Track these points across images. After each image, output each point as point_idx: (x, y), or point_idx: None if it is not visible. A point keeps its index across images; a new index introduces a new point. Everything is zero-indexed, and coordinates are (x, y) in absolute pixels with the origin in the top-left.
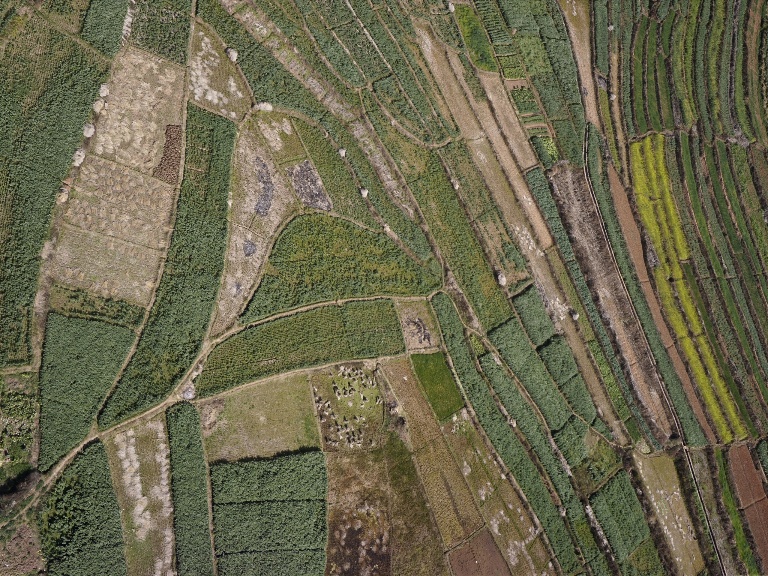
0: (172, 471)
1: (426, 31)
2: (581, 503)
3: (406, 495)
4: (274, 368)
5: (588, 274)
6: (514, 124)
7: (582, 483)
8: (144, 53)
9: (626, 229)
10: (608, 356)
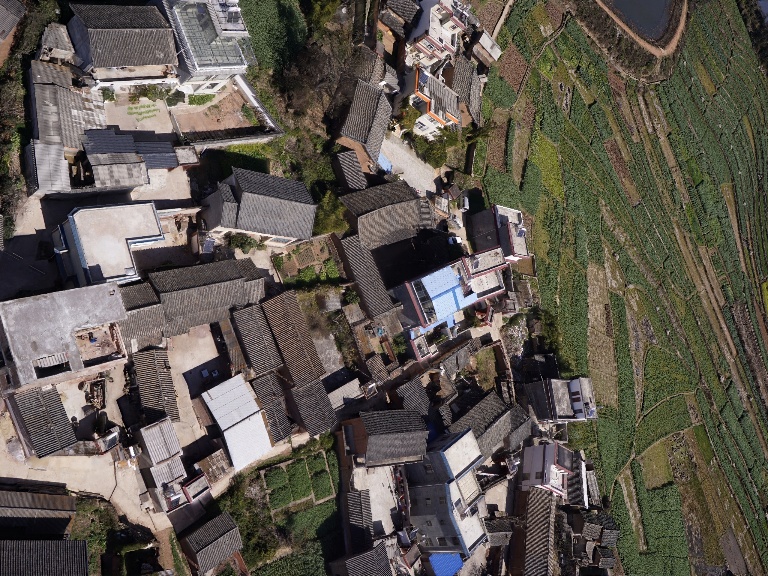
0: (638, 495)
1: (675, 224)
2: (763, 511)
3: (702, 507)
4: (654, 438)
5: (754, 372)
6: (714, 278)
7: (763, 499)
8: (592, 263)
9: (765, 341)
10: (765, 422)
